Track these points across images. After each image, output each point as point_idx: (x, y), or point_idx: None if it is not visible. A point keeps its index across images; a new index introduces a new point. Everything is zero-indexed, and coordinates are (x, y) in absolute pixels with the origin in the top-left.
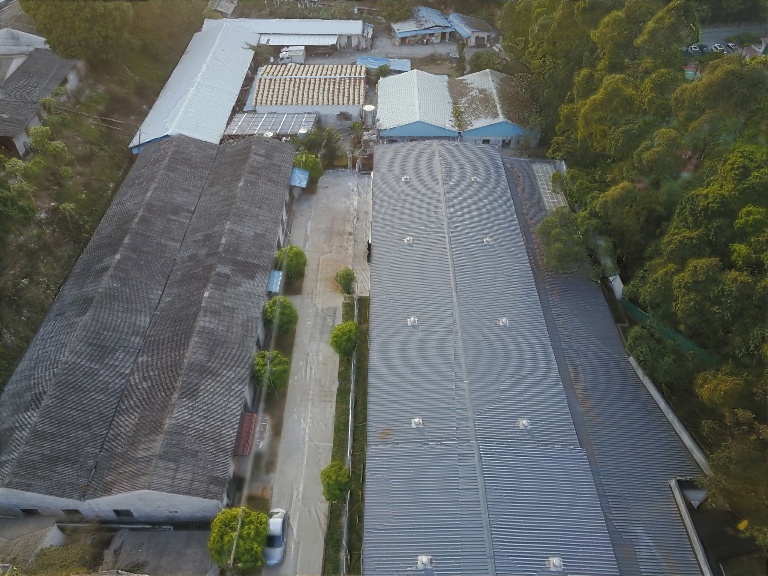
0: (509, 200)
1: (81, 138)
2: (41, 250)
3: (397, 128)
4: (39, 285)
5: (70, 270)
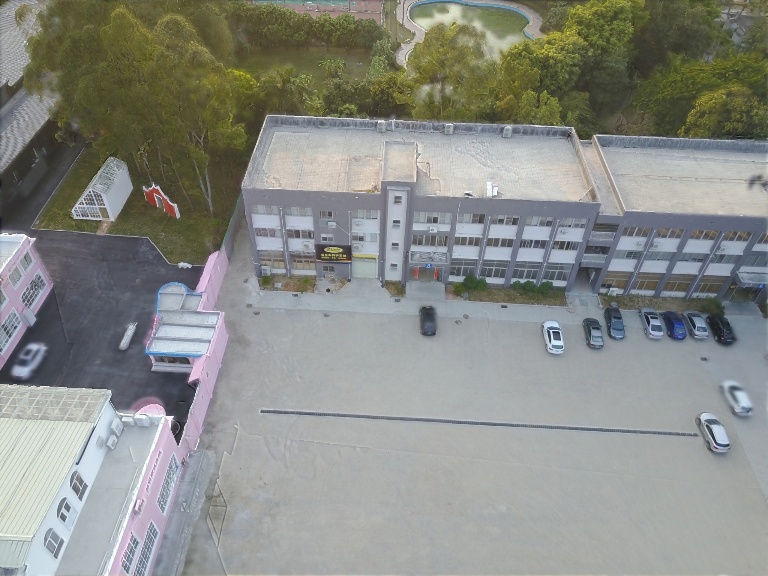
0: None
1: None
2: None
3: None
4: None
5: None
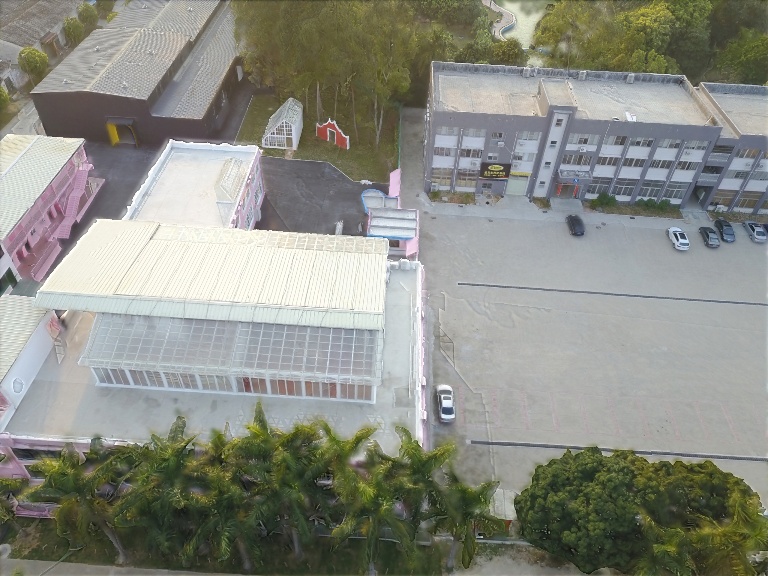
0: None
1: None
2: None
3: None
4: None
5: None
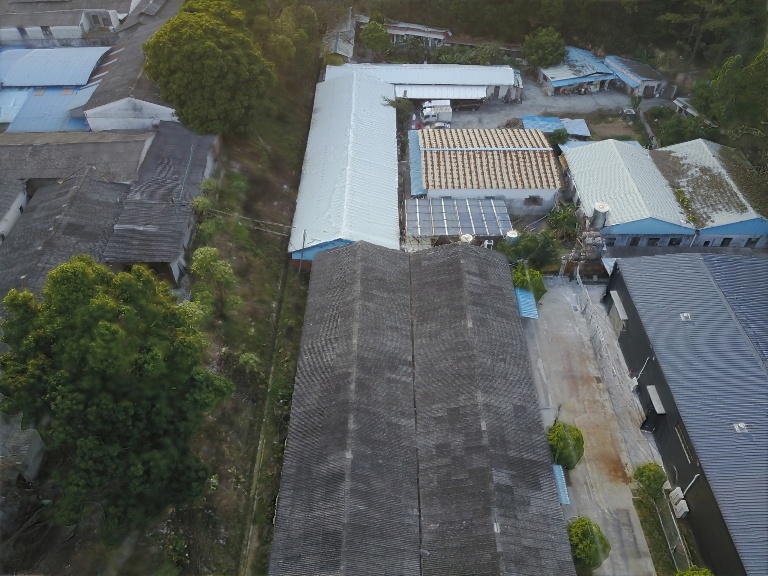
0: None
1: (233, 243)
2: (221, 422)
3: (620, 225)
4: (229, 480)
5: (255, 444)
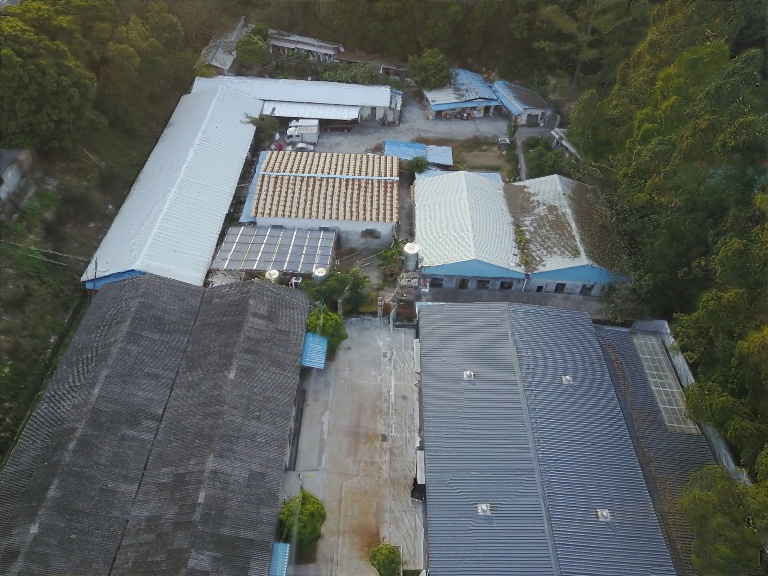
0: (621, 422)
1: (13, 270)
2: None
3: (445, 266)
4: None
5: None
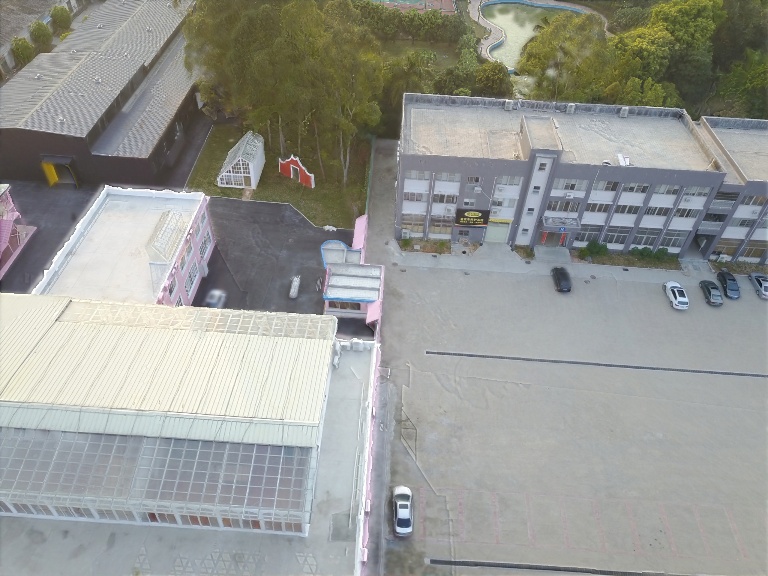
0: None
1: None
2: None
3: None
4: None
5: None
